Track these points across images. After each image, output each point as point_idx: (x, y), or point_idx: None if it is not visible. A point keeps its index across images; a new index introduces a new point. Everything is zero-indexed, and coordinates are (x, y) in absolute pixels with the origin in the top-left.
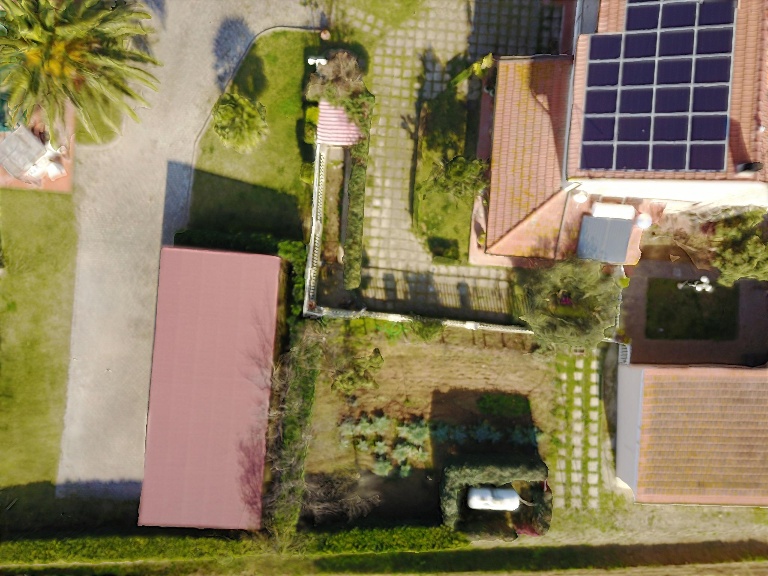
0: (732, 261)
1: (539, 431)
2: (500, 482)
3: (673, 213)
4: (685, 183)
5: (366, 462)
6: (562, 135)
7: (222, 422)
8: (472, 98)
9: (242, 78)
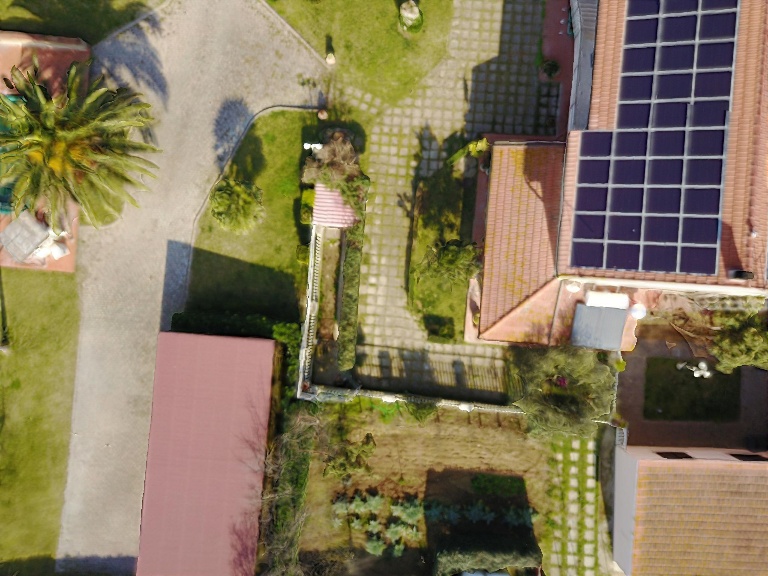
0: (729, 352)
1: (535, 512)
2: (493, 568)
3: (672, 293)
4: (676, 285)
5: (360, 540)
6: (555, 223)
7: (216, 504)
8: (468, 176)
9: (241, 157)
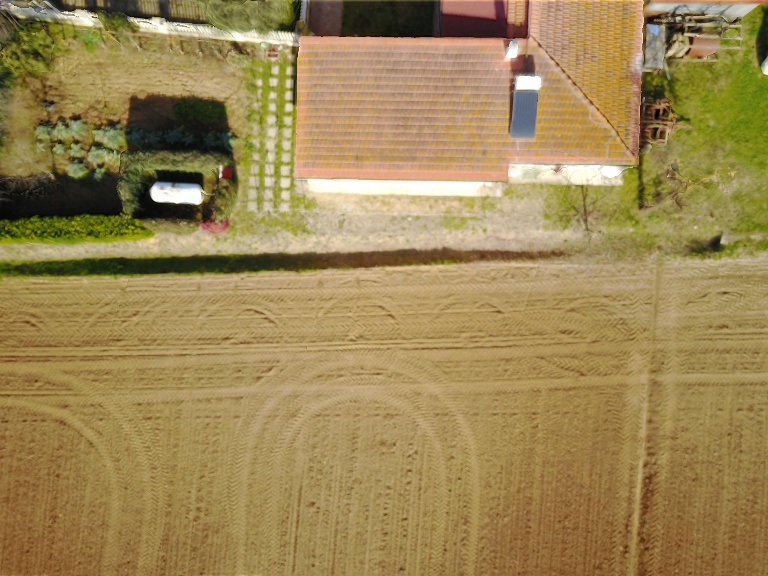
0: None
1: (234, 136)
2: (174, 166)
3: None
4: None
5: (63, 166)
6: None
7: None
8: None
9: None
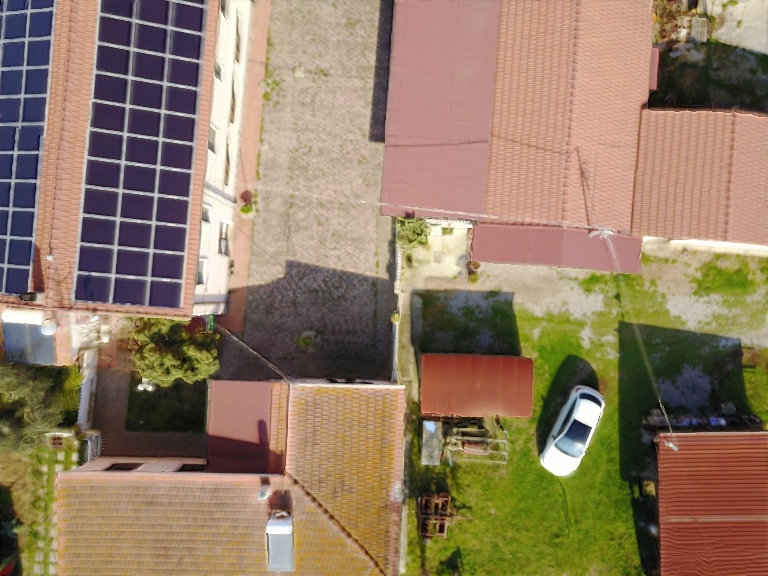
0: (140, 367)
1: (19, 523)
2: None
3: None
4: None
5: None
6: None
7: None
8: None
9: None
